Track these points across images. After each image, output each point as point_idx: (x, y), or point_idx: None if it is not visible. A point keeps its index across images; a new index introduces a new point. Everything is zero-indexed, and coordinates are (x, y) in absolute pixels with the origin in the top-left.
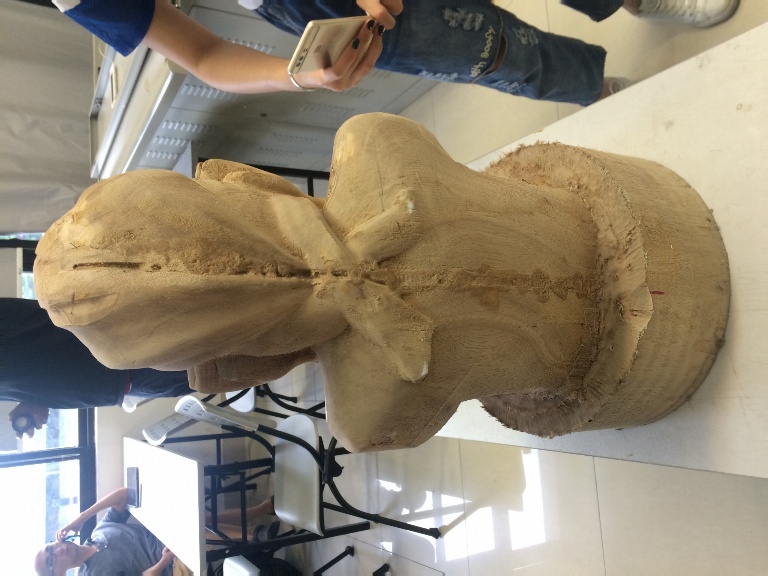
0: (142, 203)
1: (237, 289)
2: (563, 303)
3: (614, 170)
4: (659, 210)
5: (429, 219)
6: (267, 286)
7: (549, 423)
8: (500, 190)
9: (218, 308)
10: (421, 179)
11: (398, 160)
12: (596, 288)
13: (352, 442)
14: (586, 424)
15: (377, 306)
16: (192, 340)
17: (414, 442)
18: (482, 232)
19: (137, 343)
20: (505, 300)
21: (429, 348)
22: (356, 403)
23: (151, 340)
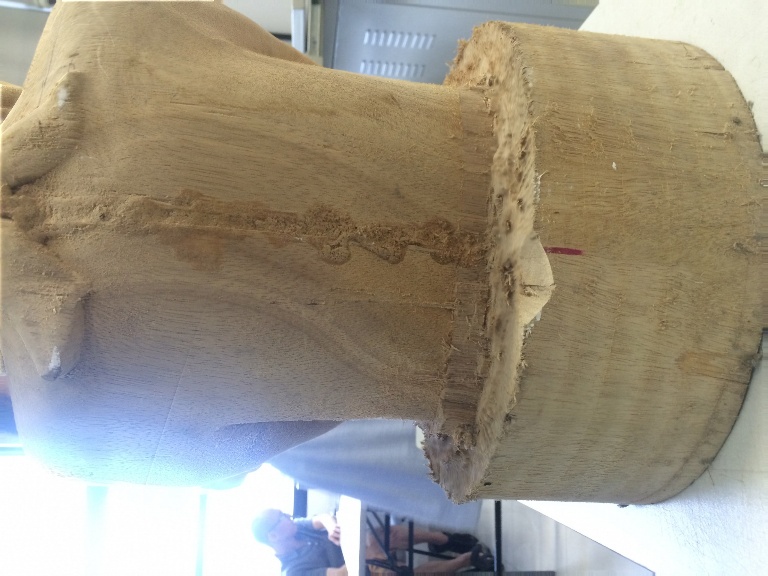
0: None
1: None
2: (392, 269)
3: (535, 42)
4: (604, 102)
5: (96, 116)
6: None
7: (455, 479)
8: (277, 77)
9: None
10: (103, 56)
11: (80, 32)
12: (485, 248)
13: (36, 467)
14: (491, 488)
15: None
16: None
17: (153, 480)
18: (193, 137)
19: None
20: (236, 253)
21: (67, 324)
22: (18, 407)
23: None
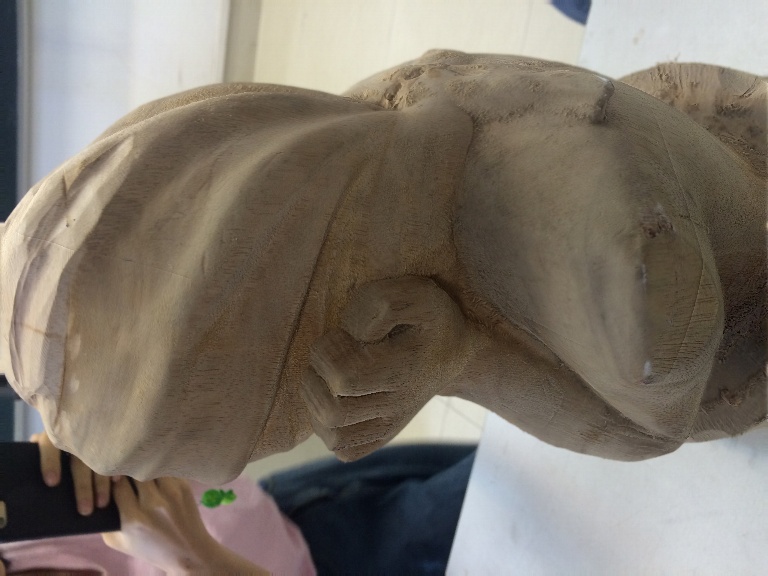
0: (131, 117)
1: (301, 98)
2: None
3: None
4: None
5: None
6: (339, 101)
7: None
8: None
9: (290, 124)
10: None
11: None
12: None
13: (620, 247)
14: None
15: (484, 71)
16: (276, 155)
17: None
18: None
19: (194, 216)
20: None
21: None
22: (570, 186)
23: (214, 189)
